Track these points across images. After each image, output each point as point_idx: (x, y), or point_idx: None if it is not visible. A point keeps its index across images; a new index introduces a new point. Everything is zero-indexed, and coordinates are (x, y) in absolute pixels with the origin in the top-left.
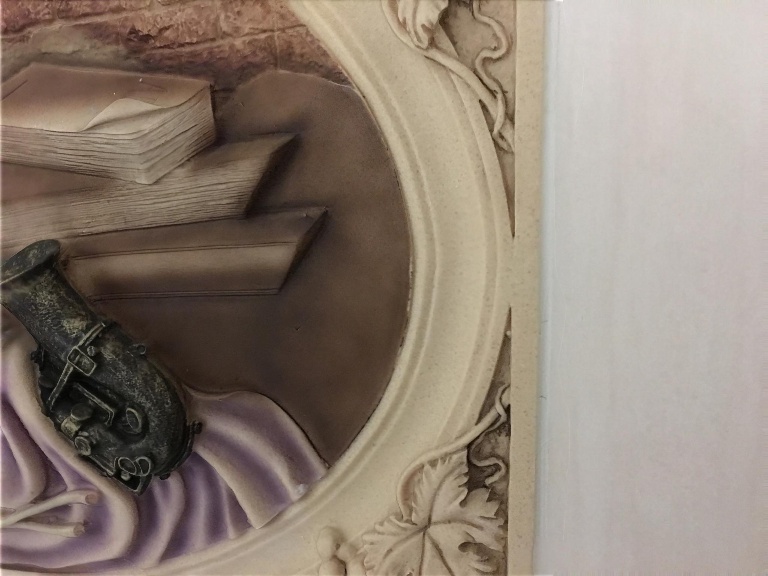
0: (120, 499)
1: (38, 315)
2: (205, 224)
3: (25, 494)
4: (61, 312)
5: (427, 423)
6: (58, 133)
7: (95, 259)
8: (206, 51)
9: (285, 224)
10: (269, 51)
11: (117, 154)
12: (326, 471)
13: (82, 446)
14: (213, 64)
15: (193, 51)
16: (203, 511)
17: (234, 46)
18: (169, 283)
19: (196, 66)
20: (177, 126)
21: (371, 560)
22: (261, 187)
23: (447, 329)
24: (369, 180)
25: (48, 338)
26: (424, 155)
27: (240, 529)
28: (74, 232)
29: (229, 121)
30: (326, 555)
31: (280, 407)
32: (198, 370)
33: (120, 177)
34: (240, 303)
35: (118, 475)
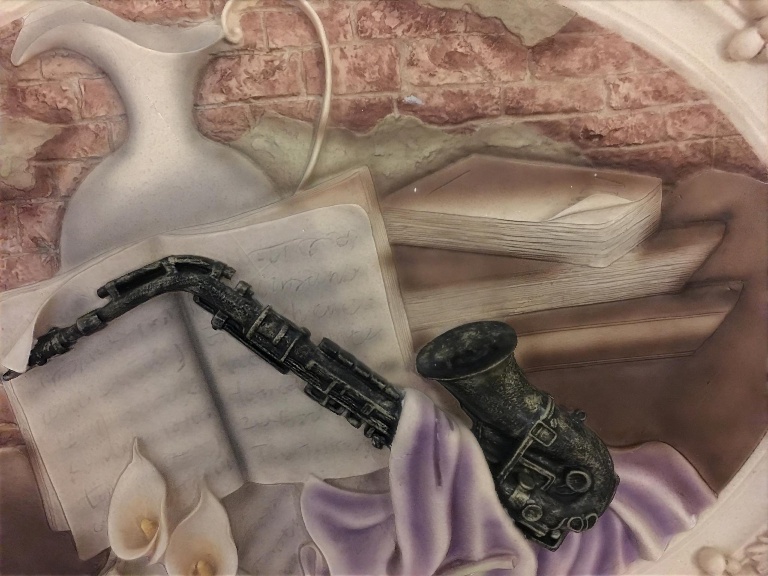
0: (533, 558)
1: (505, 395)
2: (641, 300)
3: (430, 572)
4: (524, 390)
5: None
6: (514, 222)
7: (530, 336)
8: (652, 151)
9: (717, 297)
10: (708, 154)
11: (575, 241)
12: (716, 500)
13: (530, 513)
14: (656, 162)
15: (640, 151)
16: (594, 555)
17: (677, 148)
18: (596, 353)
19: (642, 164)
20: (635, 217)
21: (766, 567)
22: (701, 267)
23: None
24: None
25: (509, 416)
26: None
27: (627, 564)
28: (505, 312)
29: (669, 211)
30: (719, 571)
31: (678, 451)
32: (611, 428)
33: (571, 261)
34: (655, 365)
35: (548, 535)
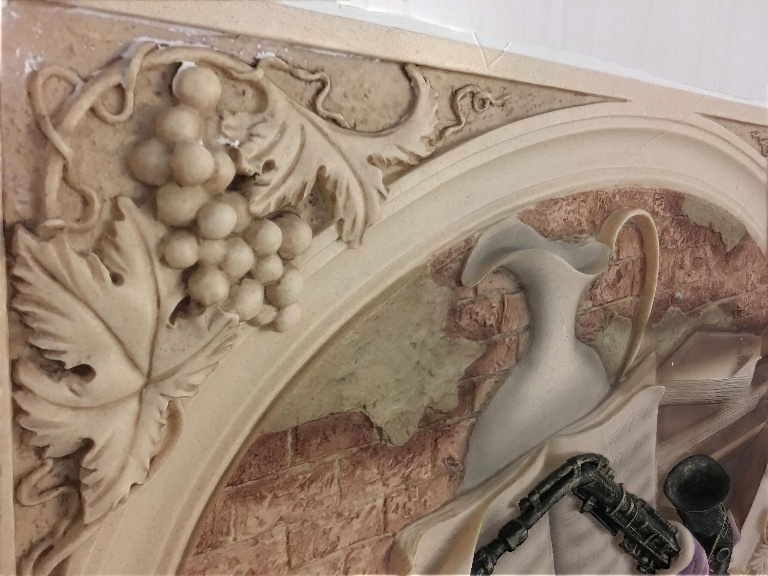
0: None
1: None
2: None
3: None
4: None
5: (767, 490)
6: None
7: None
8: (755, 318)
9: (767, 408)
10: None
11: (735, 388)
12: None
13: None
14: None
15: None
16: None
17: None
18: None
19: None
20: None
21: (761, 573)
22: None
23: None
24: None
25: None
26: None
27: None
28: (695, 444)
29: None
30: None
31: (731, 512)
32: None
33: (729, 401)
34: None
35: None
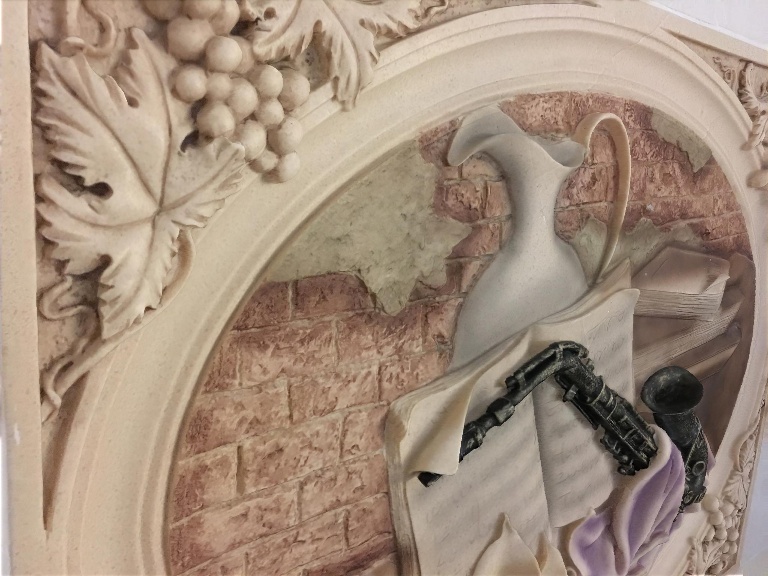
0: None
1: None
2: None
3: None
4: None
5: (739, 420)
6: None
7: None
8: None
9: None
10: (737, 244)
11: (706, 305)
12: None
13: None
14: None
15: (719, 242)
16: None
17: None
18: None
19: None
20: None
21: (735, 498)
22: None
23: (749, 372)
24: (749, 306)
25: None
26: (760, 292)
27: None
28: None
29: None
30: None
31: None
32: None
33: None
34: None
35: None
